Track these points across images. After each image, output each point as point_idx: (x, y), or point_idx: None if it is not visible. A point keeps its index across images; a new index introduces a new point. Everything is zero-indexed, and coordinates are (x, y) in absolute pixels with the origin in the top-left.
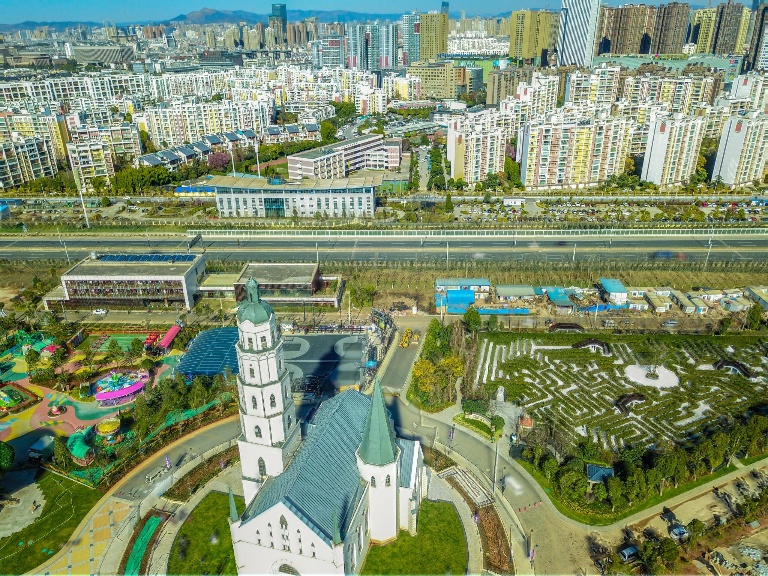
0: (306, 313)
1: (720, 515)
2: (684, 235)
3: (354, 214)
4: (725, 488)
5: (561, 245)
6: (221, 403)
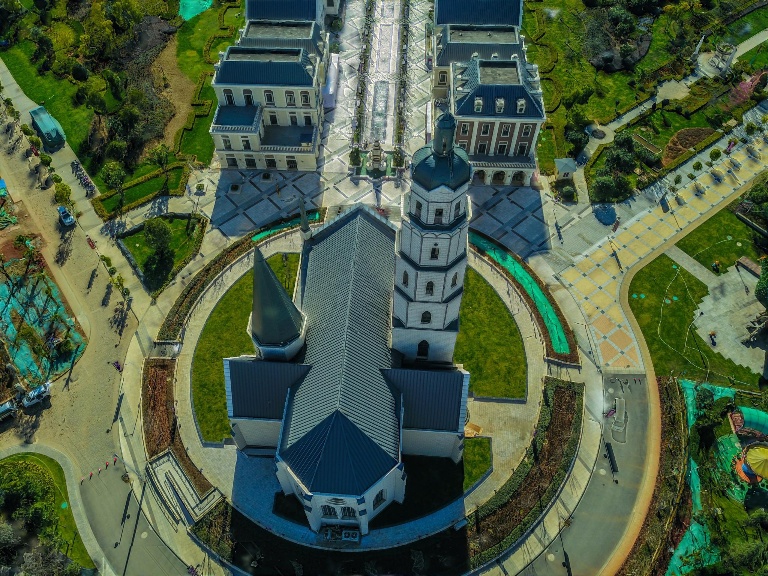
0: None
1: None
2: None
3: None
4: None
5: None
6: (636, 572)
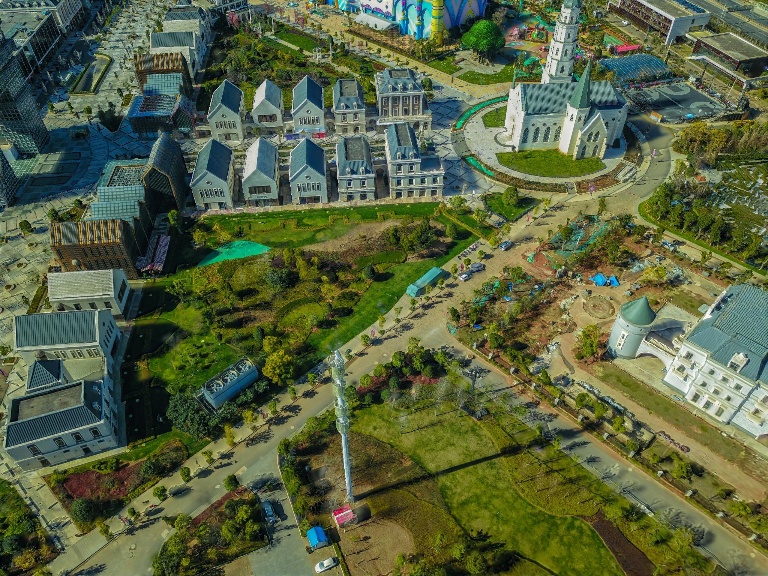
0: (722, 82)
1: None
2: None
3: None
4: (734, 268)
5: None
6: None
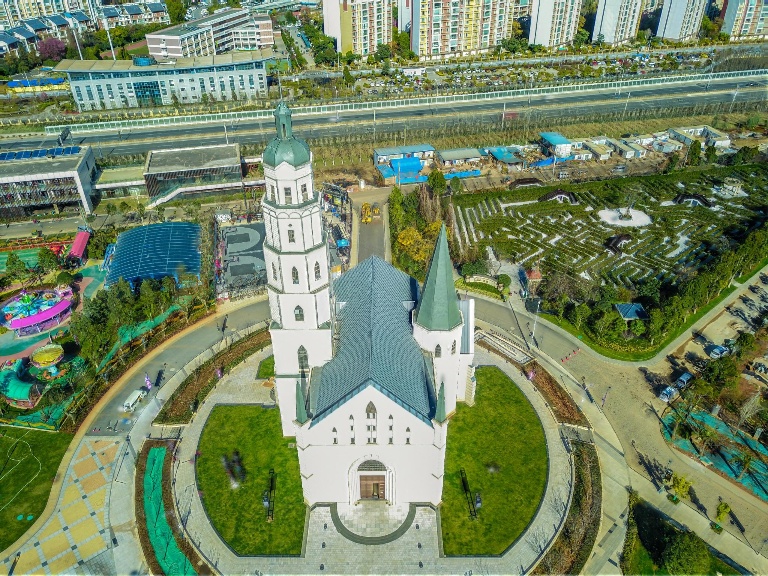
0: (238, 201)
1: (743, 330)
2: (591, 90)
3: (246, 95)
4: (735, 306)
5: (480, 109)
6: (186, 307)
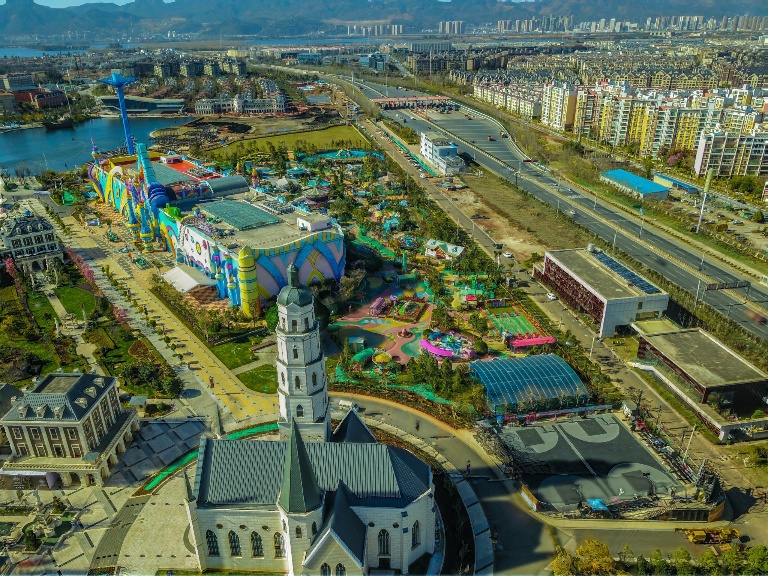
0: (682, 418)
1: None
2: None
3: None
4: None
5: None
6: None
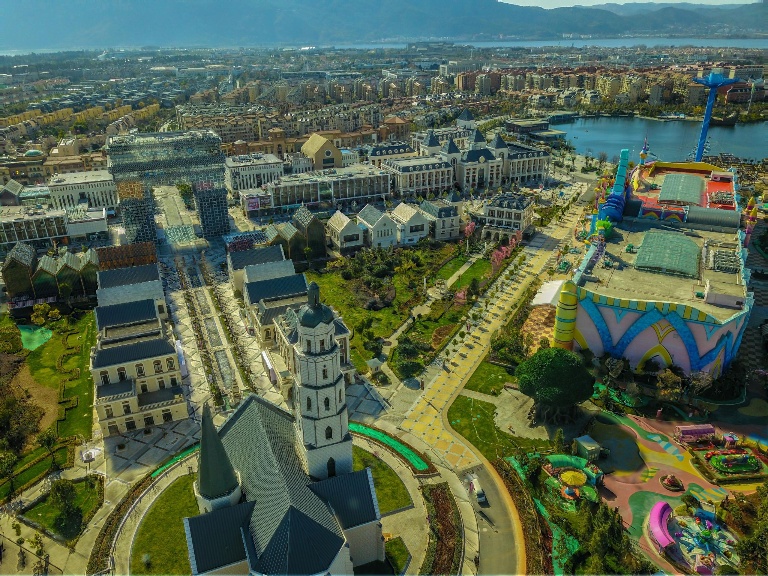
0: None
1: None
2: None
3: None
4: None
5: None
6: (534, 570)
